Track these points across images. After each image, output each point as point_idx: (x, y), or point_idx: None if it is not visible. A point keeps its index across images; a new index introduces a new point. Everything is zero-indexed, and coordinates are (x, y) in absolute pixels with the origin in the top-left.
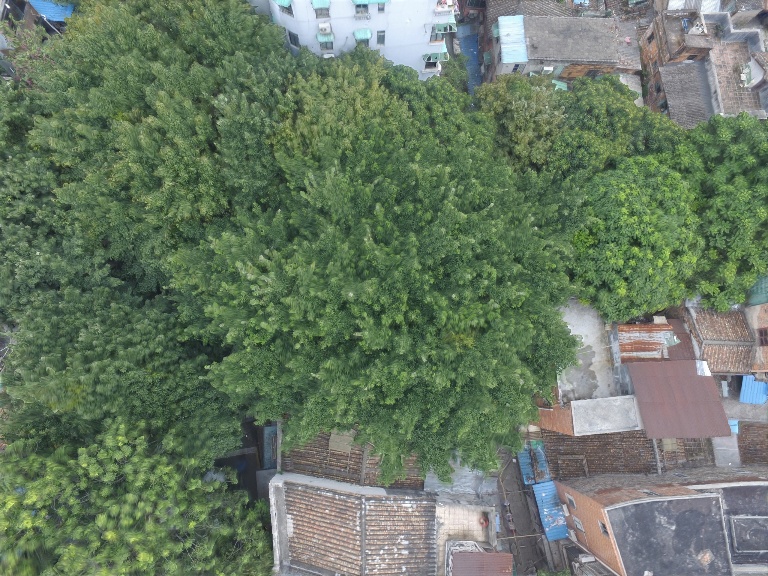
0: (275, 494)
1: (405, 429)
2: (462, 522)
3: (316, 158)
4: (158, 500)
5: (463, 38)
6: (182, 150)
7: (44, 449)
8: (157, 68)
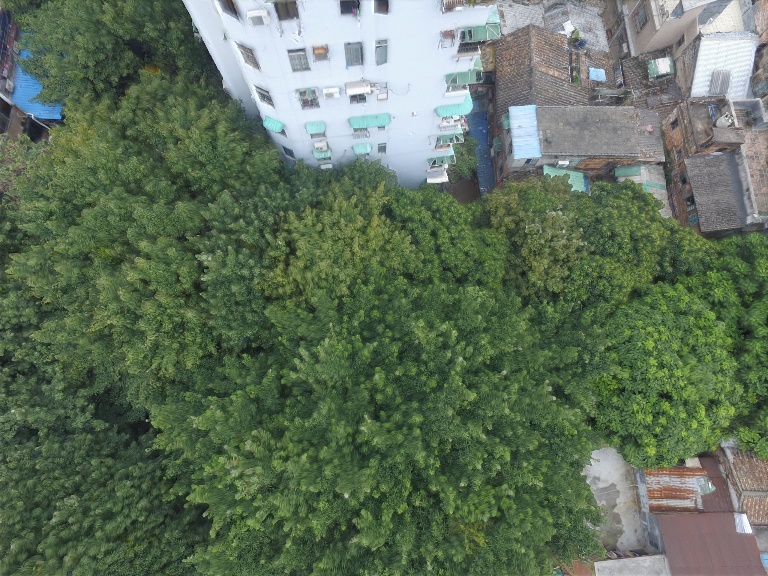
0: None
1: None
2: None
3: (311, 303)
4: None
5: (471, 115)
6: (165, 303)
7: None
8: (138, 213)
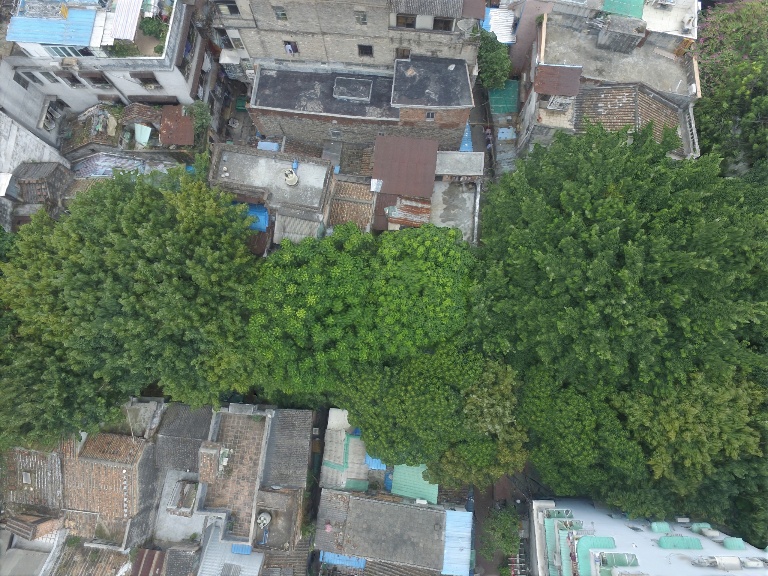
0: (691, 152)
1: None
2: (554, 121)
3: None
4: None
5: None
6: None
7: None
8: None
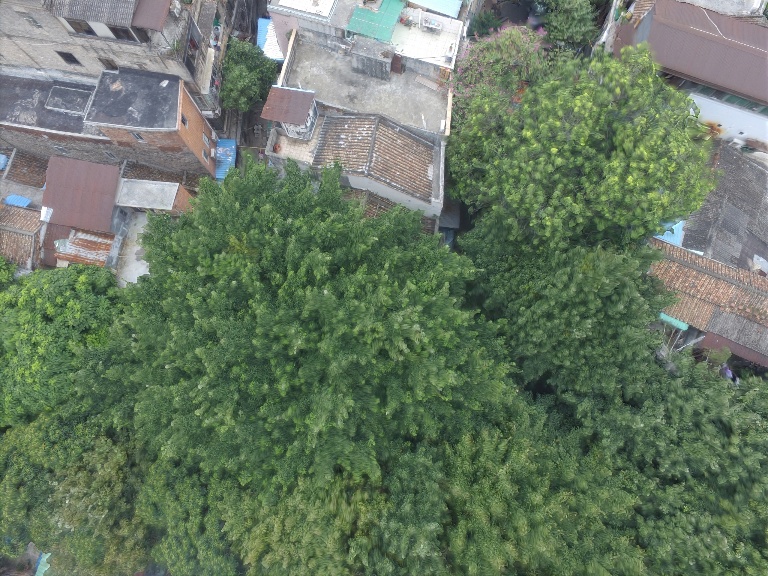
0: None
1: (310, 189)
2: (294, 151)
3: None
4: (518, 175)
5: None
6: None
7: (618, 238)
8: None
